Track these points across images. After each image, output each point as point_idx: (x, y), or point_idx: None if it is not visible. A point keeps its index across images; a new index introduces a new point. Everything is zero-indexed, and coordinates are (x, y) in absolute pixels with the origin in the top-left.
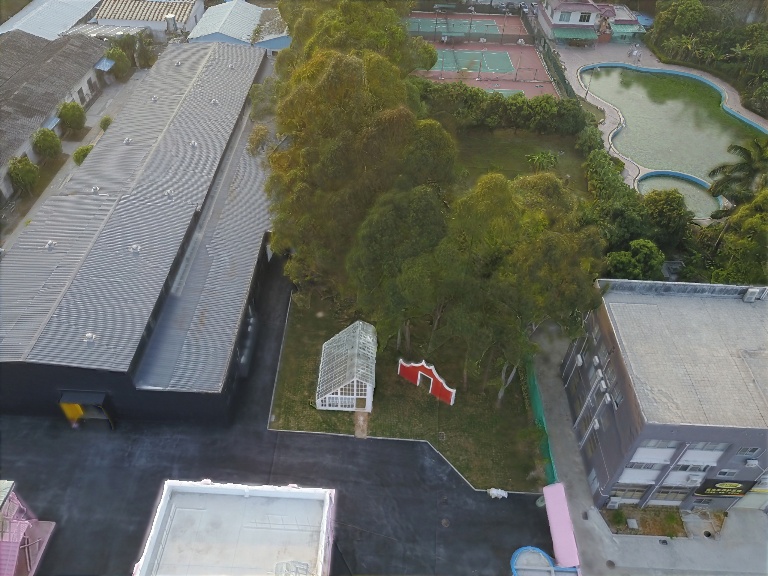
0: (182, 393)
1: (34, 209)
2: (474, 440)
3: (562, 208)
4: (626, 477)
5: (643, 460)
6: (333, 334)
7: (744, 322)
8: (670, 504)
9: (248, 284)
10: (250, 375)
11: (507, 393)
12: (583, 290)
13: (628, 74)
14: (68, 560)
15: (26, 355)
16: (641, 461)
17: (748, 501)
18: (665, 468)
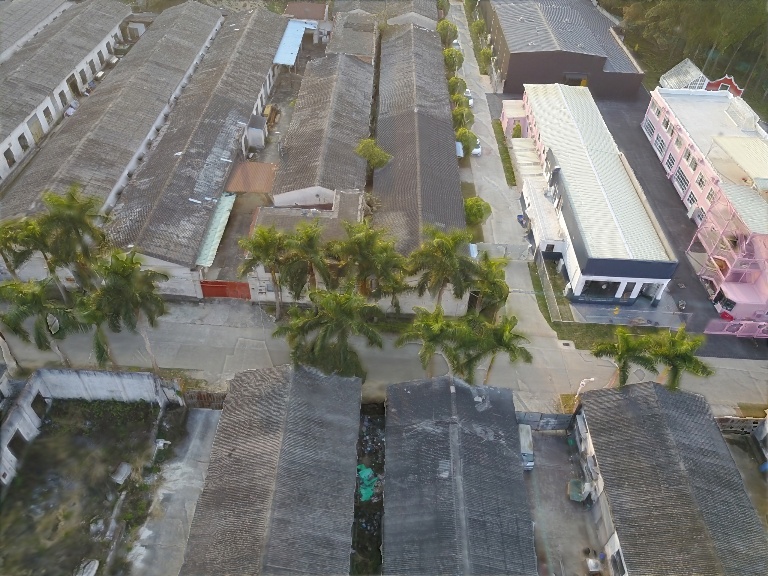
0: (626, 74)
1: None
2: (757, 111)
3: None
4: None
5: None
6: (659, 77)
7: None
8: None
9: (619, 45)
10: None
11: None
12: None
13: None
14: None
15: None
16: None
17: None
18: None
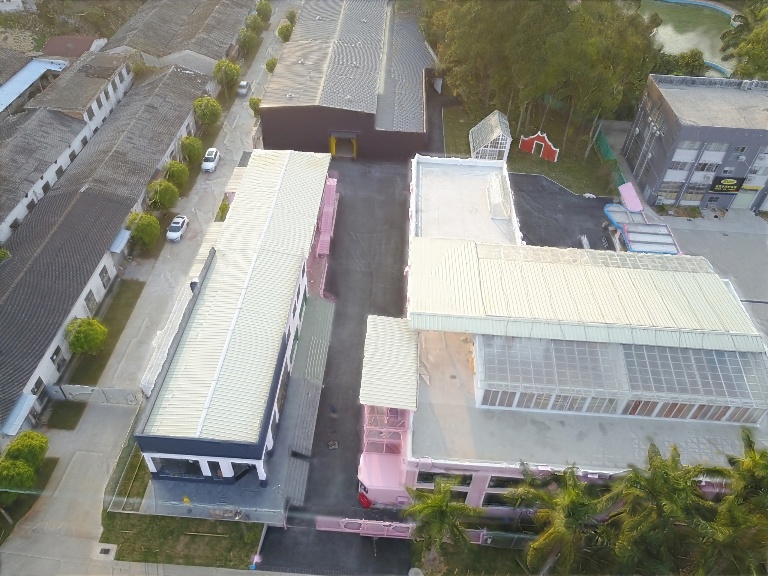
0: (403, 132)
1: (254, 65)
2: (572, 176)
3: (638, 4)
4: (668, 177)
5: (679, 160)
6: None
7: (740, 98)
8: (693, 204)
9: (422, 92)
10: (428, 142)
11: (589, 158)
12: (650, 43)
13: (658, 3)
14: (352, 208)
15: (318, 103)
16: (678, 160)
17: (741, 202)
18: (692, 167)
